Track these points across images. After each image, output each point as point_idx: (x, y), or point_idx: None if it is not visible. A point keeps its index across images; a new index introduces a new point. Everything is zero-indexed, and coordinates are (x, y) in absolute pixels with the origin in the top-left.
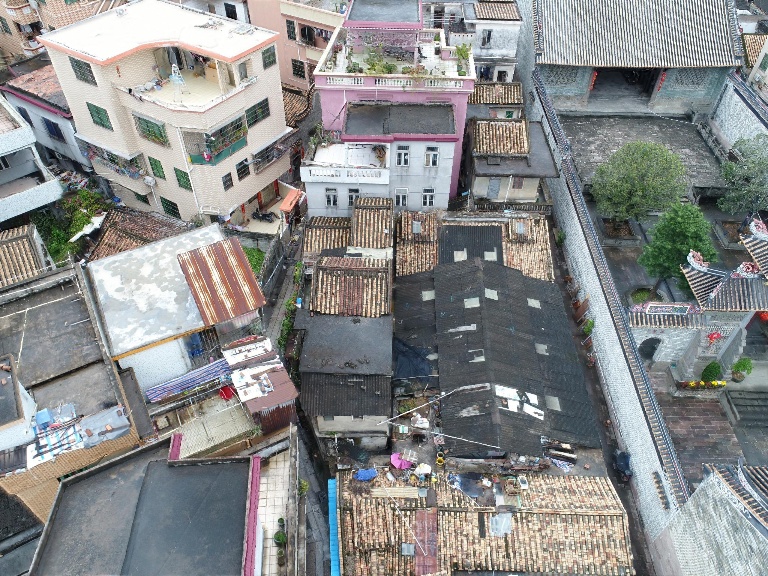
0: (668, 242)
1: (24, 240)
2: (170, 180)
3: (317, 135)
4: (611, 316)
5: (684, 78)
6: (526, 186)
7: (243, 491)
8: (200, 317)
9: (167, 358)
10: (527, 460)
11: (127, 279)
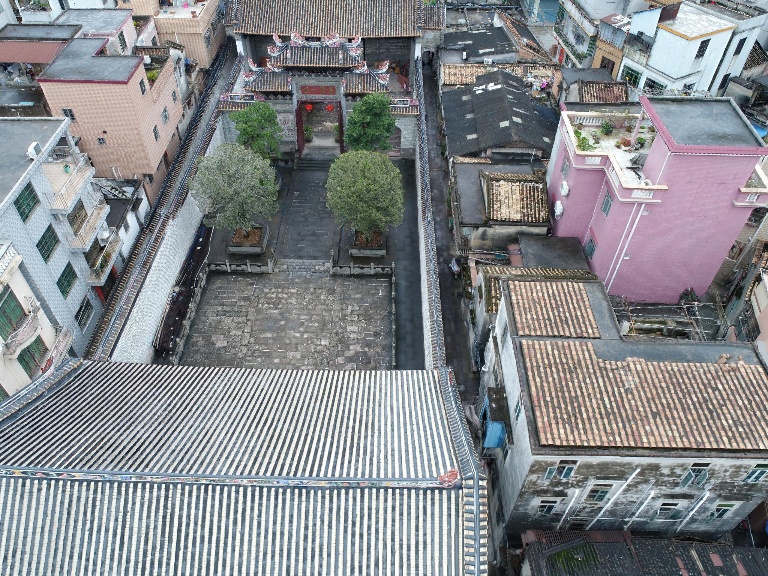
0: None
1: None
2: None
3: None
4: None
5: None
6: None
7: None
8: None
9: None
10: None
11: (709, 20)
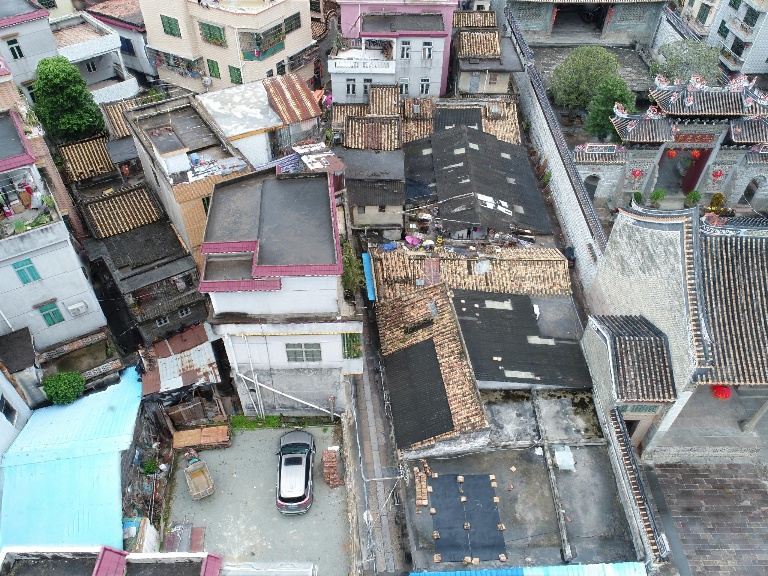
0: (603, 107)
1: (132, 101)
2: (224, 78)
3: (338, 41)
4: (562, 160)
5: (628, 14)
6: (499, 81)
7: (325, 188)
8: (279, 120)
9: (257, 148)
10: (500, 238)
11: (225, 103)
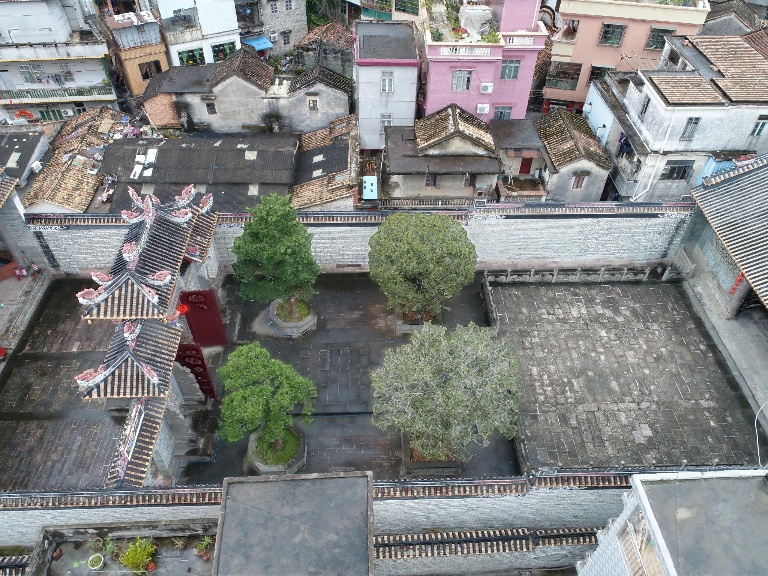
0: None
1: None
2: None
3: None
4: None
5: None
6: None
7: None
8: None
9: None
10: None
11: None
